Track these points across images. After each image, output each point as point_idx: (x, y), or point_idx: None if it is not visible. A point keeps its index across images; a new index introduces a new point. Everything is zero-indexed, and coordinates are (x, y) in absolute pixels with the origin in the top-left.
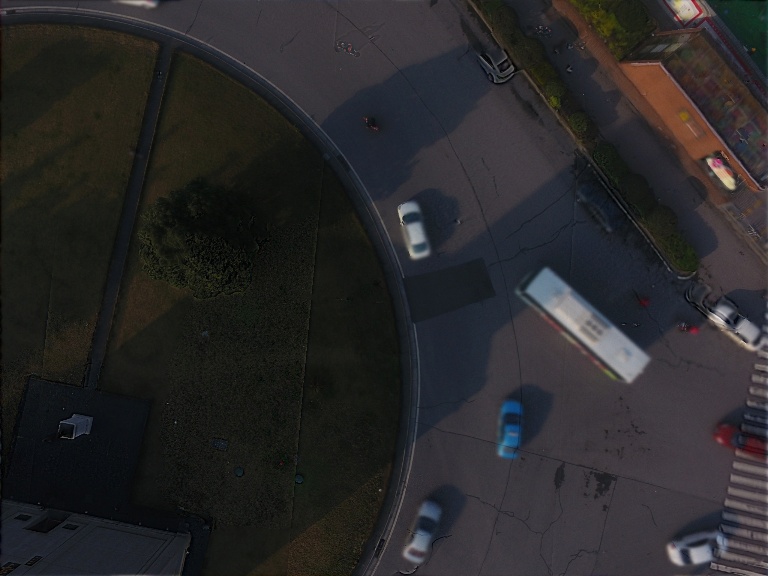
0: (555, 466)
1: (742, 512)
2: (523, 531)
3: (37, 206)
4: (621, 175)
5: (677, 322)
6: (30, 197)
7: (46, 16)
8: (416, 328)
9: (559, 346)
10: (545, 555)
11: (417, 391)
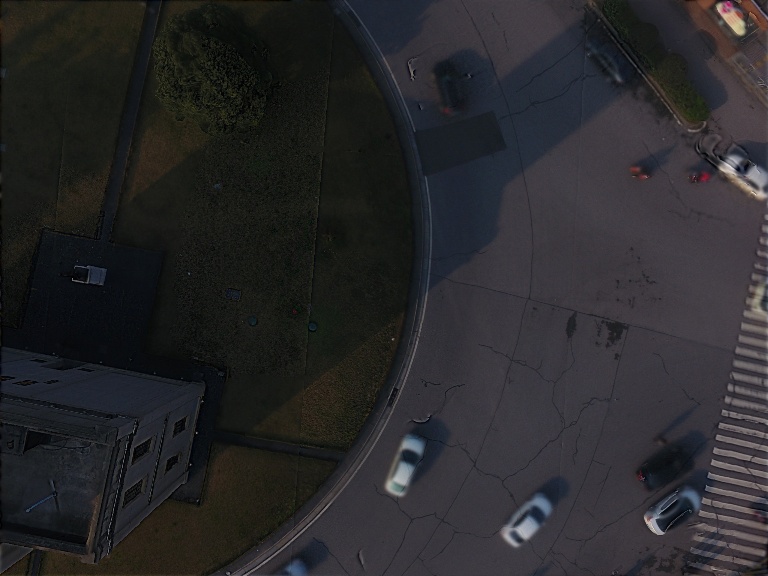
0: (567, 316)
1: (753, 360)
2: (535, 380)
3: (48, 60)
4: (631, 25)
5: (687, 174)
6: (41, 51)
7: None
8: (427, 181)
9: (570, 198)
10: (557, 403)
11: (429, 243)
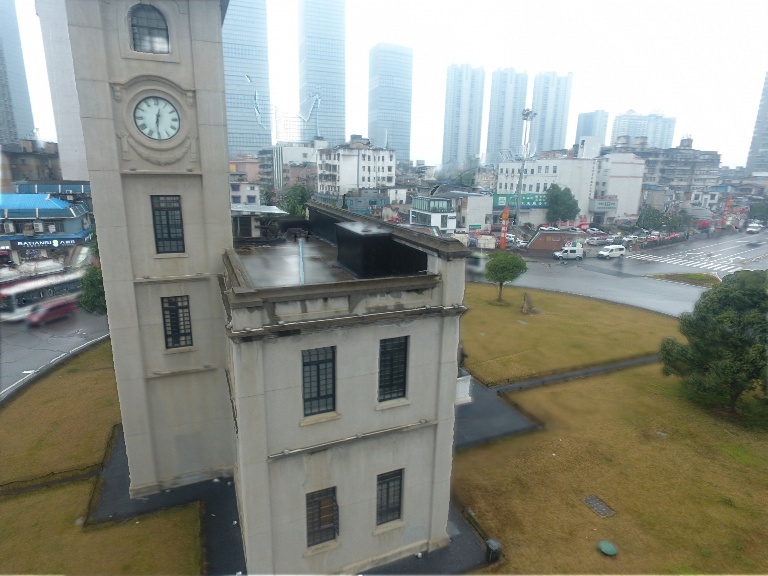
0: None
1: None
2: None
3: (563, 331)
4: None
5: None
6: (562, 328)
7: (647, 309)
8: None
9: None
10: None
11: None
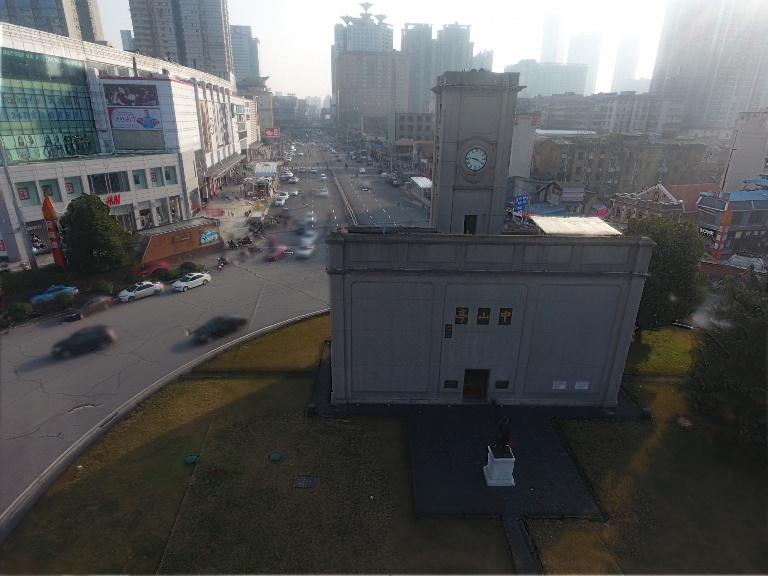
0: None
1: None
2: None
3: None
4: None
5: None
6: None
7: None
8: None
9: None
10: None
11: None
